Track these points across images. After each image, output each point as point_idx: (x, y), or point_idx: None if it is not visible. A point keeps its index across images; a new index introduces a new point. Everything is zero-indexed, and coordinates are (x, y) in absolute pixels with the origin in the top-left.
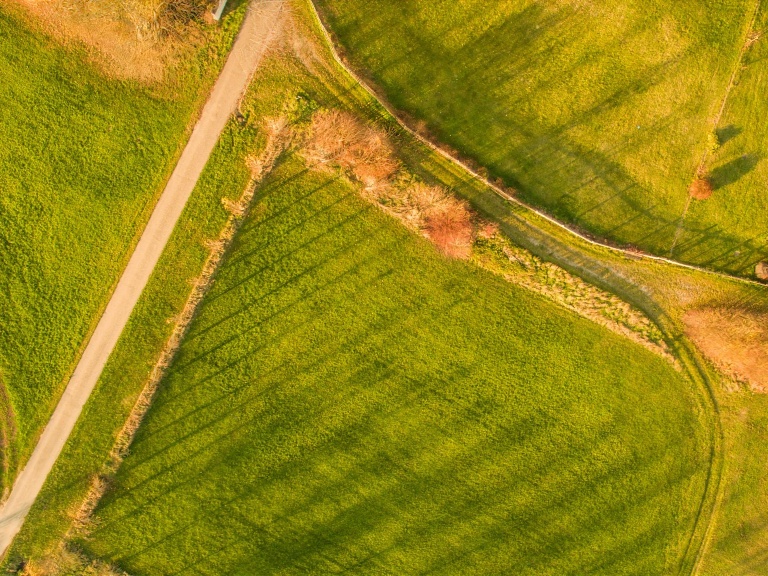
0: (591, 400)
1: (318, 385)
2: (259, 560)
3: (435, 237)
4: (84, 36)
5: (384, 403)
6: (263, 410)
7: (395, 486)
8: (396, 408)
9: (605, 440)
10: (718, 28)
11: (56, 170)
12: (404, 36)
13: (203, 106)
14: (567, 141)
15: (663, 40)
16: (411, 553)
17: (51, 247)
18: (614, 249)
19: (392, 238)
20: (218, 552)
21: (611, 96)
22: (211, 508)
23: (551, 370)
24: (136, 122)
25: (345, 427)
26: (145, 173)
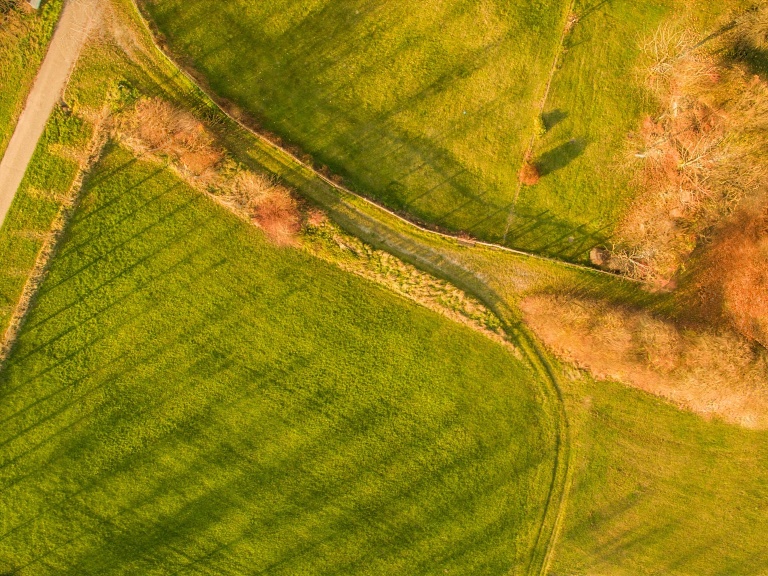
0: (433, 389)
1: (158, 376)
2: (107, 553)
3: (265, 226)
4: None
5: (225, 394)
6: (103, 402)
7: (240, 477)
8: (237, 399)
9: (449, 429)
10: (537, 11)
11: None
12: (224, 23)
13: (27, 96)
14: (393, 127)
15: (482, 24)
16: (259, 545)
17: None
18: (446, 236)
19: (223, 227)
20: (65, 545)
21: (435, 81)
22: (56, 501)
23: (391, 359)
24: None
25: (187, 418)
26: None
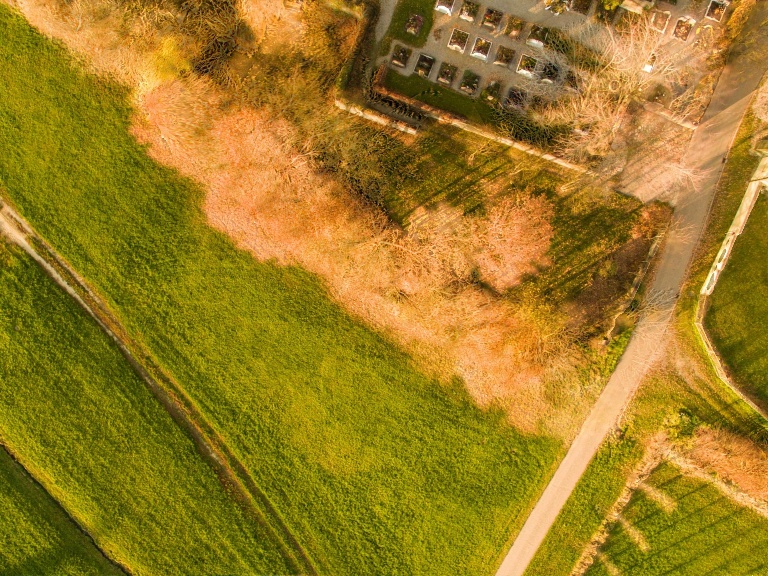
0: None
1: None
2: None
3: None
4: (461, 357)
5: None
6: None
7: None
8: None
9: None
10: None
11: (428, 479)
12: None
13: (583, 422)
14: None
15: None
16: None
17: (421, 550)
18: None
19: (765, 536)
20: None
21: None
22: None
23: None
24: (511, 435)
25: None
26: (519, 483)
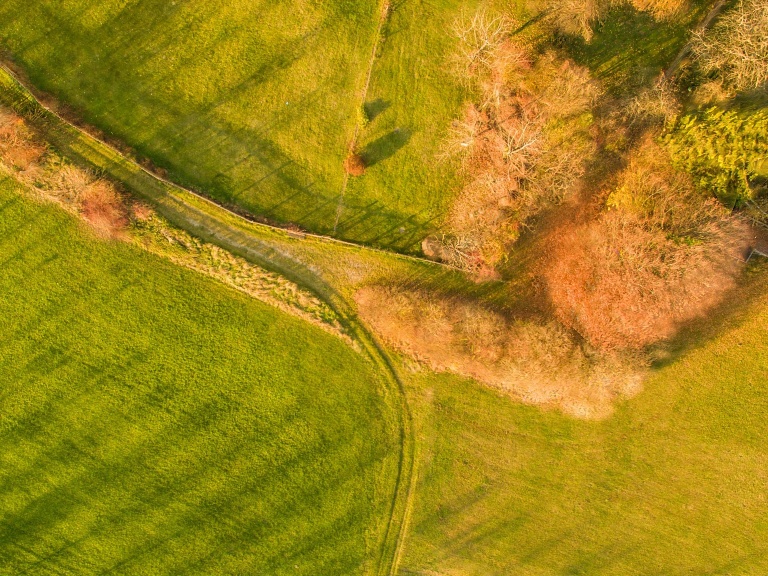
0: (273, 383)
1: None
2: None
3: (94, 220)
4: None
5: (64, 390)
6: None
7: (84, 474)
8: (77, 395)
9: (291, 423)
10: None
11: None
12: (41, 16)
13: None
14: (216, 119)
15: (298, 13)
16: (107, 542)
17: None
18: (275, 228)
19: (53, 222)
20: None
21: (256, 72)
22: None
23: (229, 353)
24: None
25: (28, 415)
26: None
